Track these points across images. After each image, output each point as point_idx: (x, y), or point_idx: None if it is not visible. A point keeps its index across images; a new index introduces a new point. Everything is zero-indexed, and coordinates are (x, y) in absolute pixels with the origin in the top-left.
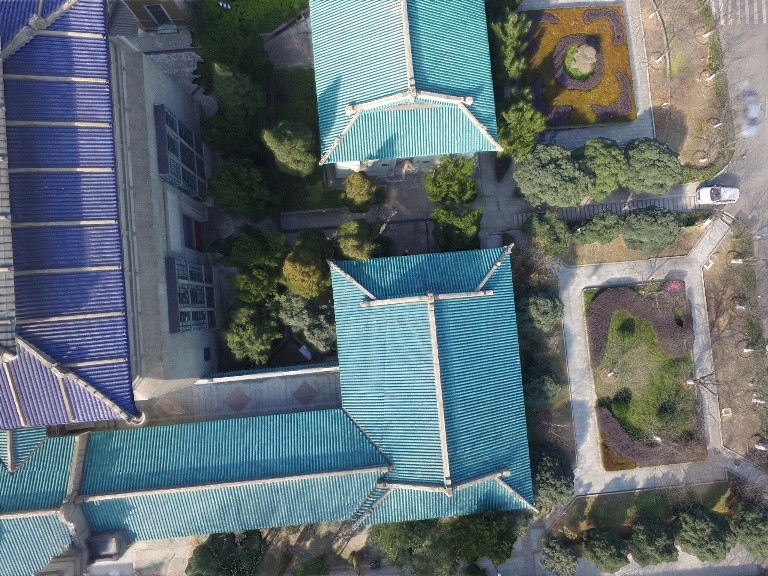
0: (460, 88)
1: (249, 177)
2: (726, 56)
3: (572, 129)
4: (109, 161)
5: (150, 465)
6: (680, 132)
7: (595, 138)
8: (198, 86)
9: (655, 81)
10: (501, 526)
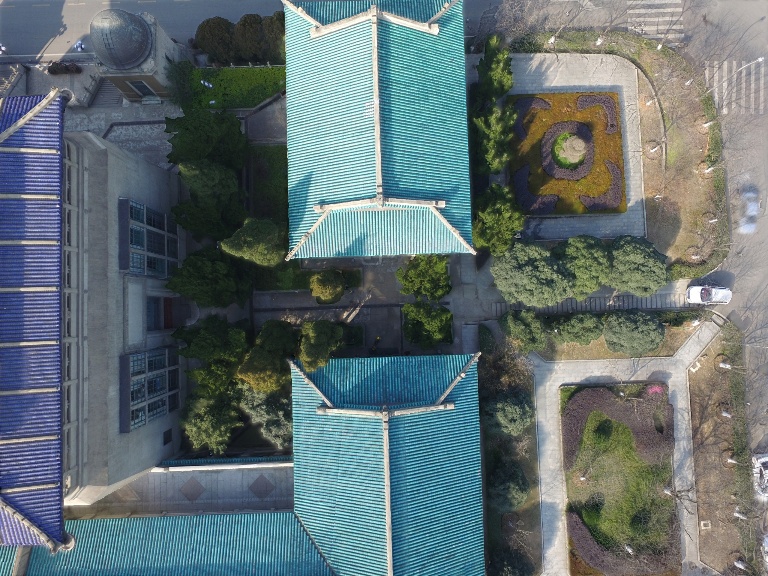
0: (433, 190)
1: (214, 269)
2: (727, 147)
3: (558, 218)
4: (54, 279)
5: (95, 561)
6: (673, 225)
7: (578, 237)
8: None
9: (649, 171)
10: None
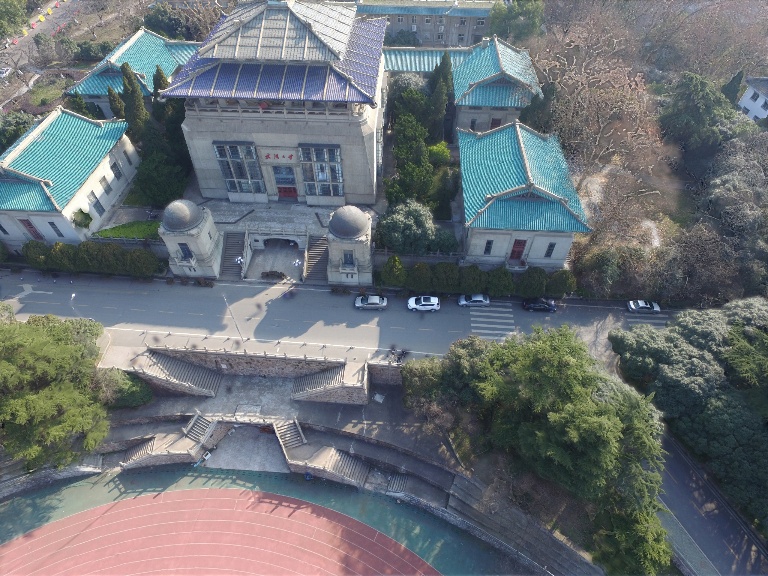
0: None
1: None
2: None
3: None
4: None
5: None
6: None
7: None
8: (199, 205)
9: None
10: None
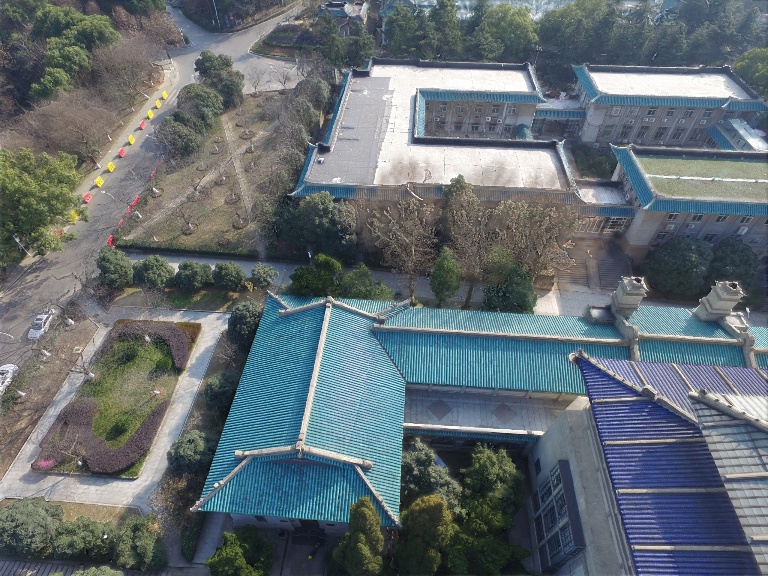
0: None
1: None
2: None
3: None
4: None
5: None
6: None
7: None
8: None
9: None
10: (298, 285)
